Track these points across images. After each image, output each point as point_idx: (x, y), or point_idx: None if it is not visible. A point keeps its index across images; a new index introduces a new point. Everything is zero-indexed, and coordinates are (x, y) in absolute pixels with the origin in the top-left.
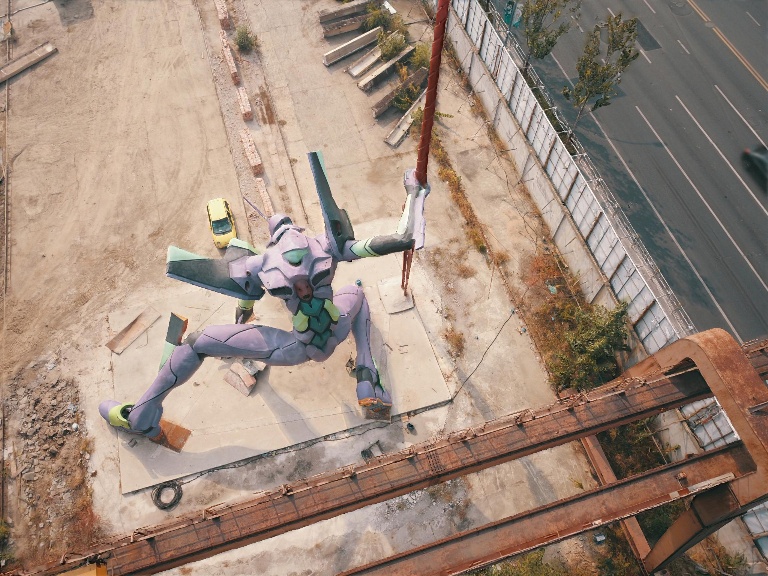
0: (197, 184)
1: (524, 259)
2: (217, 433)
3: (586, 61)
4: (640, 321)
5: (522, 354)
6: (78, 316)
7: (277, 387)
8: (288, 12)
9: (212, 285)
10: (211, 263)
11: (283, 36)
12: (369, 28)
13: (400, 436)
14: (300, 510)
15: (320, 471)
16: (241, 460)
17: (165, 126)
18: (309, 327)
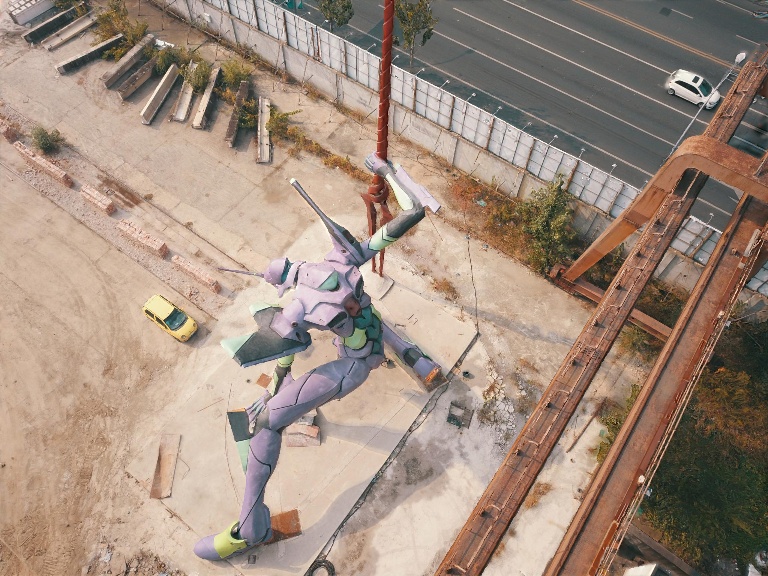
0: (111, 299)
1: (444, 193)
2: (320, 493)
3: (398, 6)
4: (570, 185)
5: (498, 265)
6: (94, 494)
7: (338, 420)
8: (66, 94)
9: (276, 353)
10: (259, 336)
11: (80, 118)
12: (162, 71)
13: (464, 387)
14: (536, 457)
15: (427, 458)
16: (359, 499)
17: (28, 265)
18: (368, 338)
